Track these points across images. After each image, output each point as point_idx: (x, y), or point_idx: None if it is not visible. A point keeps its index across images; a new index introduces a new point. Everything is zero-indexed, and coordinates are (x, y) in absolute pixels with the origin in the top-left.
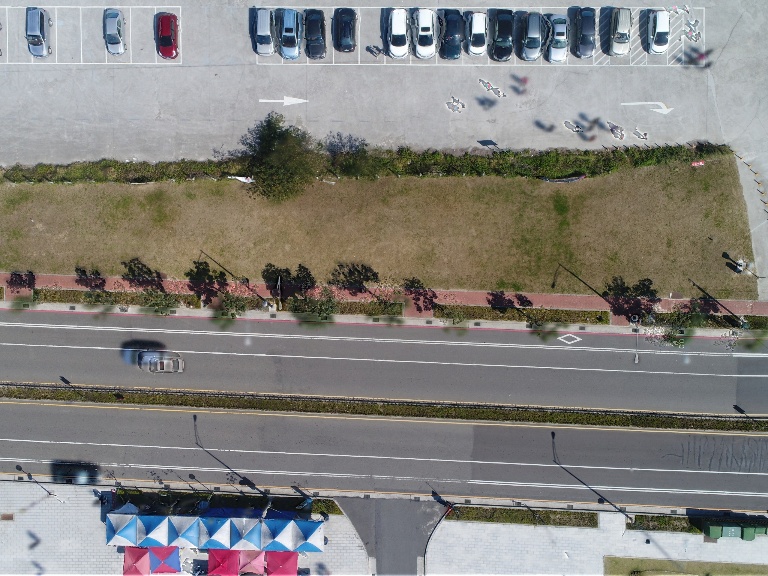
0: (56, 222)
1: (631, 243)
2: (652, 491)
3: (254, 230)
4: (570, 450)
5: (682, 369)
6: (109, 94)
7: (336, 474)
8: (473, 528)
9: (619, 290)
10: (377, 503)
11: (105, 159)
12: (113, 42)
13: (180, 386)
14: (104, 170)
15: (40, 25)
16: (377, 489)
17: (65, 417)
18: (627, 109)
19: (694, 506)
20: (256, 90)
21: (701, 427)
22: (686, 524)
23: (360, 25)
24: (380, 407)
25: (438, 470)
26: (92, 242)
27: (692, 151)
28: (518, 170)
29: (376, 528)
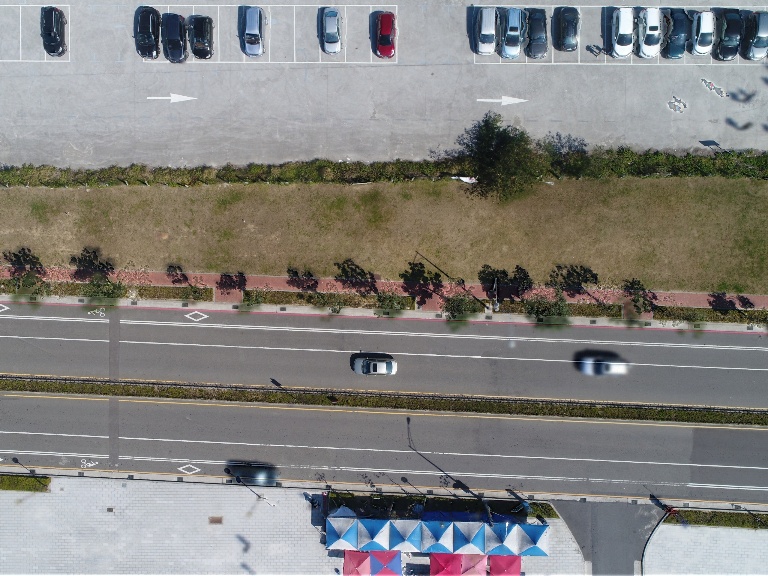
0: (268, 223)
1: None
2: None
3: (471, 231)
4: None
5: None
6: (323, 93)
7: (552, 477)
8: (692, 532)
9: None
10: (594, 506)
11: (318, 159)
12: (331, 41)
13: (393, 388)
14: (320, 170)
15: (259, 24)
16: (594, 492)
17: (275, 419)
18: None
19: None
20: (473, 90)
21: None
22: None
23: (581, 24)
24: (598, 410)
25: (656, 473)
26: (305, 243)
27: None
28: (744, 170)
29: (592, 532)
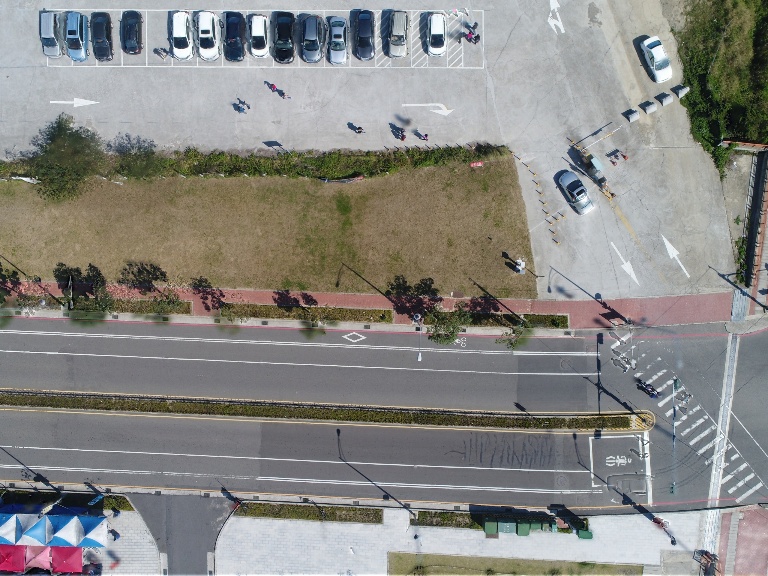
0: None
1: (412, 243)
2: (435, 487)
3: (45, 230)
4: (355, 447)
5: (464, 367)
6: None
7: (128, 471)
8: (261, 524)
9: (402, 289)
10: (168, 499)
11: None
12: None
13: None
14: None
15: None
16: (168, 485)
17: None
18: (408, 110)
19: (476, 502)
20: (47, 92)
21: (481, 424)
22: (468, 520)
23: (147, 28)
24: (169, 404)
25: (227, 467)
26: None
27: (471, 152)
28: (299, 171)
29: (167, 524)
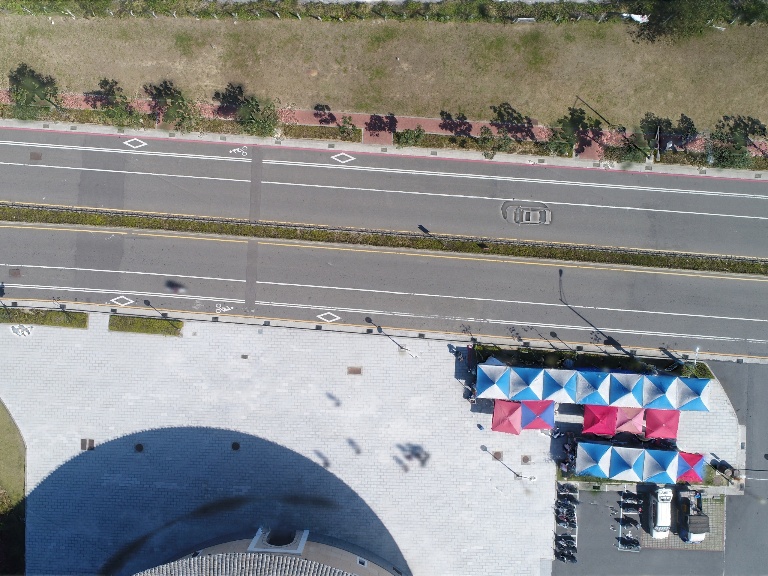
0: (423, 62)
1: None
2: None
3: (635, 76)
4: None
5: None
6: None
7: (708, 336)
8: None
9: None
10: (750, 368)
11: None
12: None
13: (547, 238)
14: (481, 7)
15: None
16: (751, 353)
17: (422, 267)
18: None
19: None
20: None
21: None
22: None
23: None
24: (761, 266)
25: None
26: (461, 84)
27: None
28: None
29: (748, 394)
